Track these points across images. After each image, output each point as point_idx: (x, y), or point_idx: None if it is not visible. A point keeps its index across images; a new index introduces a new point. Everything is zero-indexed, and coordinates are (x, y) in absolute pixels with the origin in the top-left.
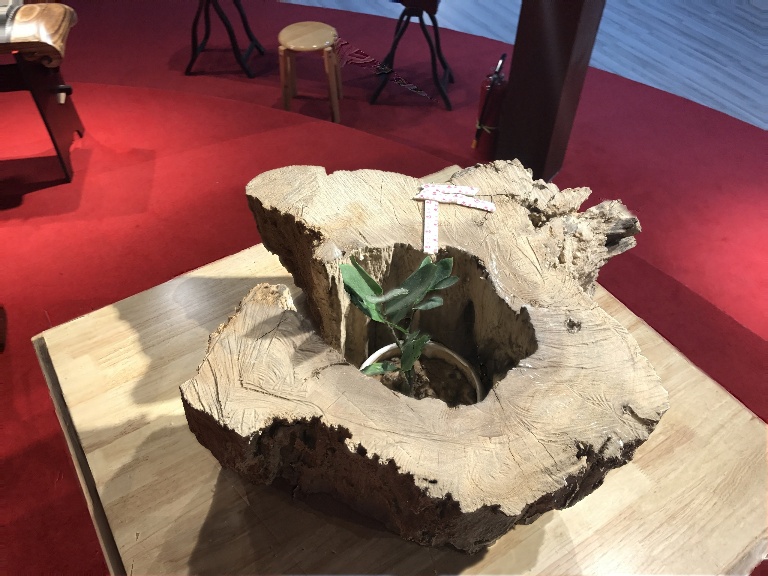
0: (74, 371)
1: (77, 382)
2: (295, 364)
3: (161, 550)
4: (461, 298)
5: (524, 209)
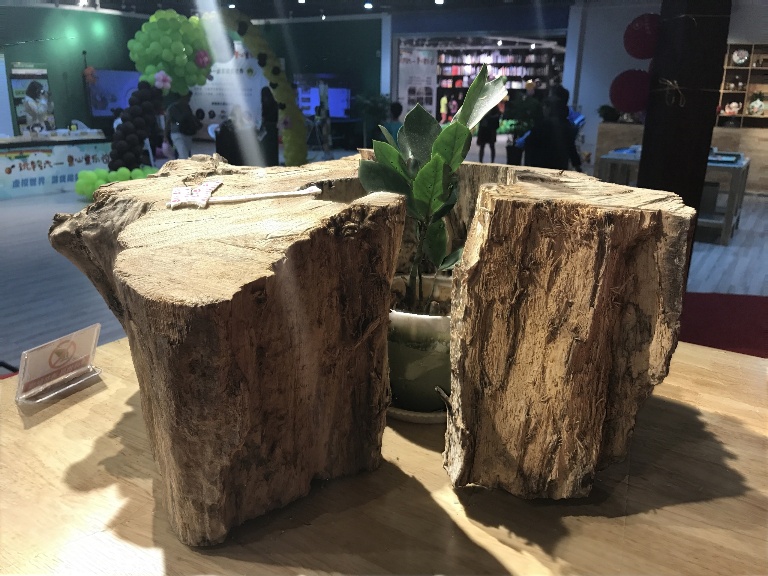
0: None
1: None
2: None
3: None
4: None
5: (212, 176)
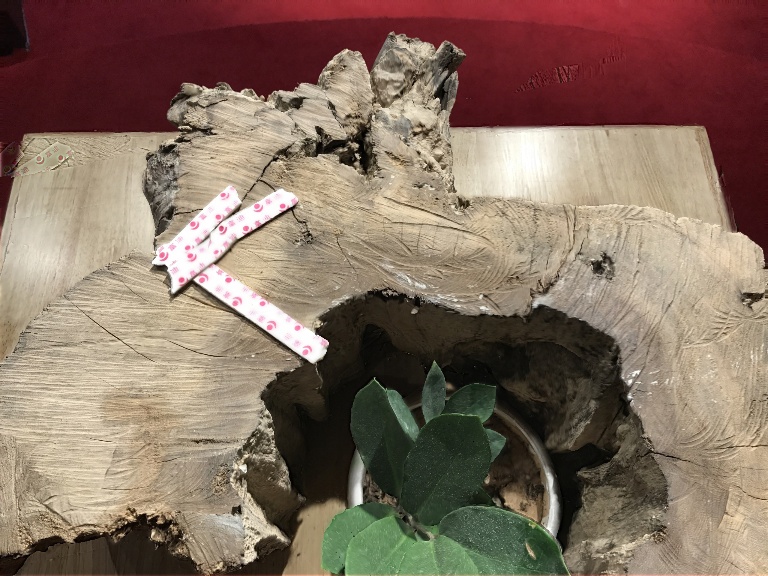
0: None
1: None
2: None
3: None
4: (356, 335)
5: (324, 158)
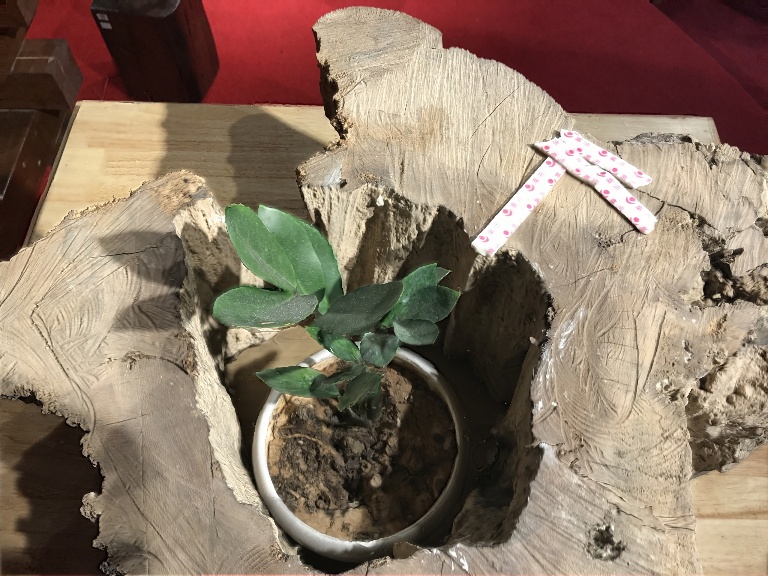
0: (80, 161)
1: (73, 175)
2: (115, 326)
3: (11, 418)
4: (519, 336)
5: (703, 256)
